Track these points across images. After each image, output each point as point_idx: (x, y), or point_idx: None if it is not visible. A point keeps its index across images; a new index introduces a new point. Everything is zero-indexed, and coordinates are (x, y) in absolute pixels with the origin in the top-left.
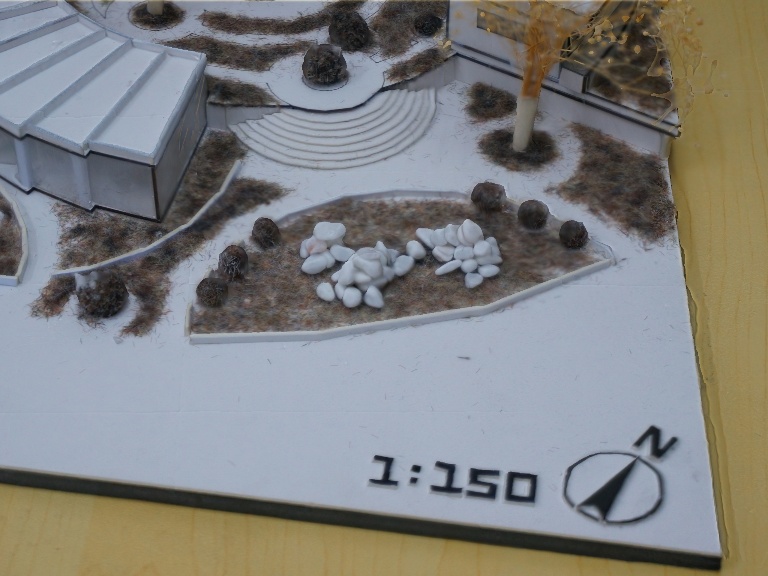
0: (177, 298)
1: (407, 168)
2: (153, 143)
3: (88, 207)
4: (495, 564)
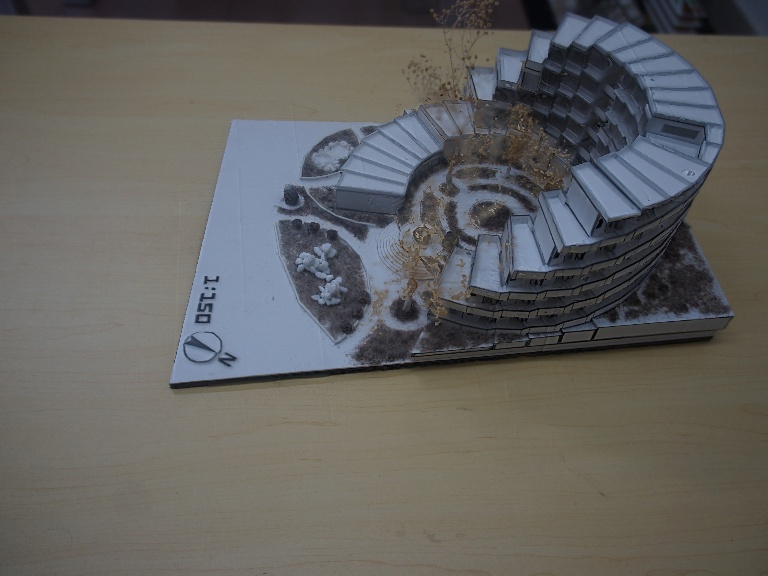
0: None
1: None
2: None
3: None
4: (176, 320)
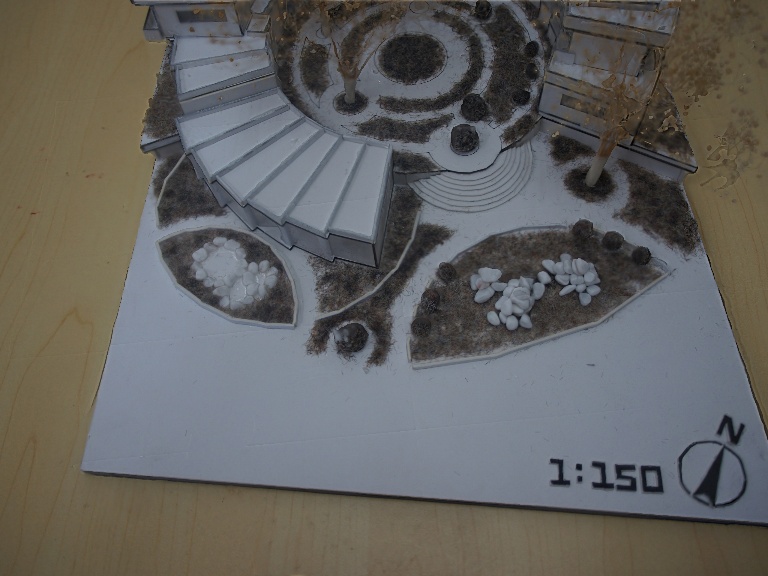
0: (398, 330)
1: (524, 206)
2: (370, 224)
3: (330, 260)
4: (640, 536)
